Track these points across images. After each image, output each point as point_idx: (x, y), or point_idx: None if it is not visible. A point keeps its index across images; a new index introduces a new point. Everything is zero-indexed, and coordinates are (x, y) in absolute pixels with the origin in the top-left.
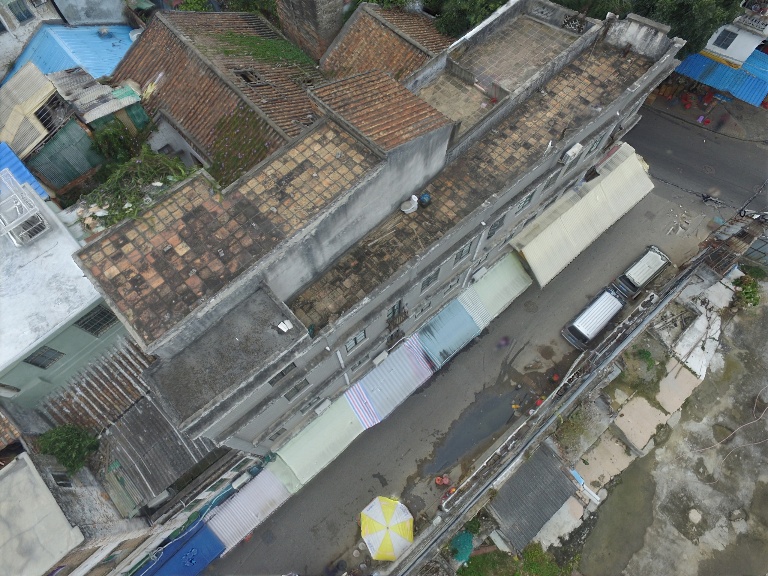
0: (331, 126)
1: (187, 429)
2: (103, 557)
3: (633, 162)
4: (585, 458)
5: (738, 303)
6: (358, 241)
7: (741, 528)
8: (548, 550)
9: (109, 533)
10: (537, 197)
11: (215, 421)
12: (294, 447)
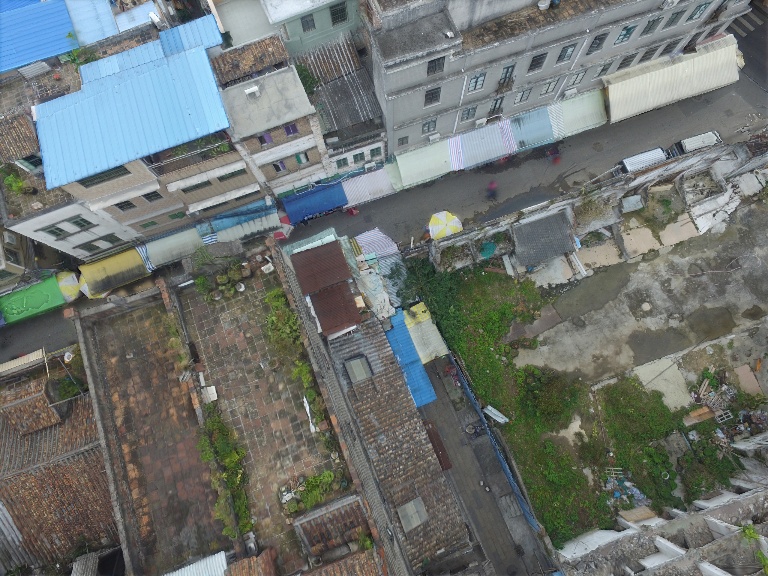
0: None
1: (386, 66)
2: (303, 150)
3: (730, 52)
4: (589, 249)
5: None
6: (503, 16)
7: (674, 324)
8: (538, 287)
9: None
10: (635, 39)
11: (401, 68)
12: (407, 159)
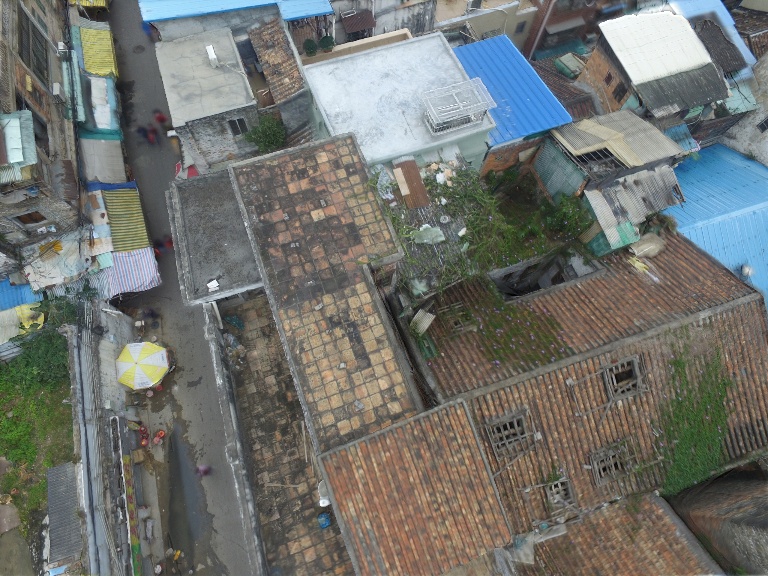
0: (408, 414)
1: None
2: None
3: None
4: None
5: None
6: None
7: None
8: None
9: (188, 148)
10: None
11: (169, 210)
12: None
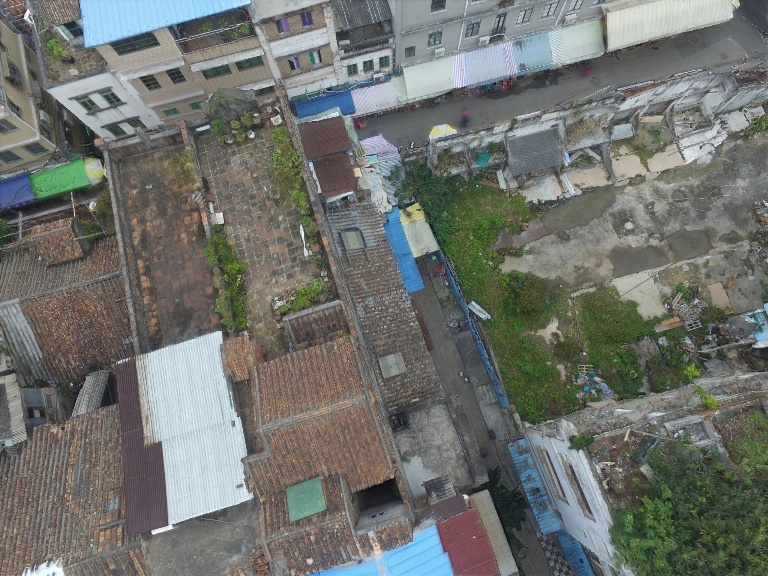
0: None
1: None
2: (317, 46)
3: None
4: (579, 171)
5: (747, 130)
6: None
7: (654, 243)
8: (528, 202)
9: None
10: None
11: None
12: (413, 73)
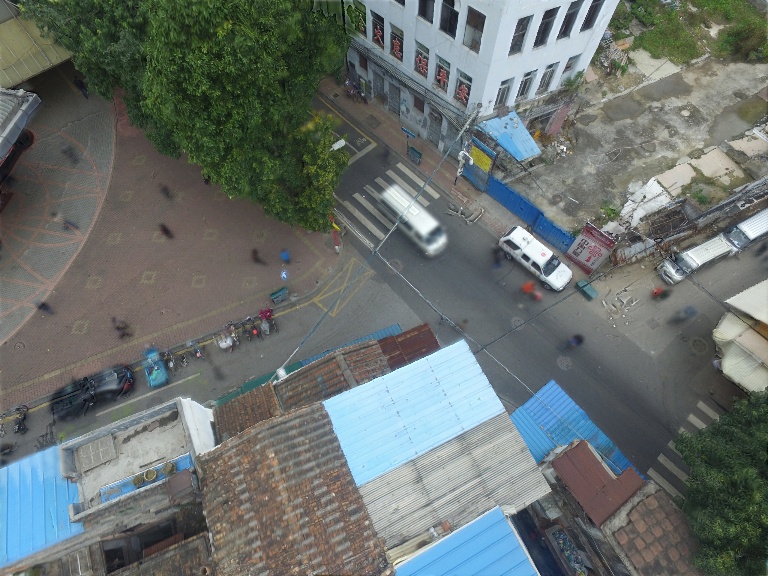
0: None
1: None
2: None
3: None
4: (761, 152)
5: None
6: None
7: (656, 103)
8: None
9: None
10: None
11: None
12: None
